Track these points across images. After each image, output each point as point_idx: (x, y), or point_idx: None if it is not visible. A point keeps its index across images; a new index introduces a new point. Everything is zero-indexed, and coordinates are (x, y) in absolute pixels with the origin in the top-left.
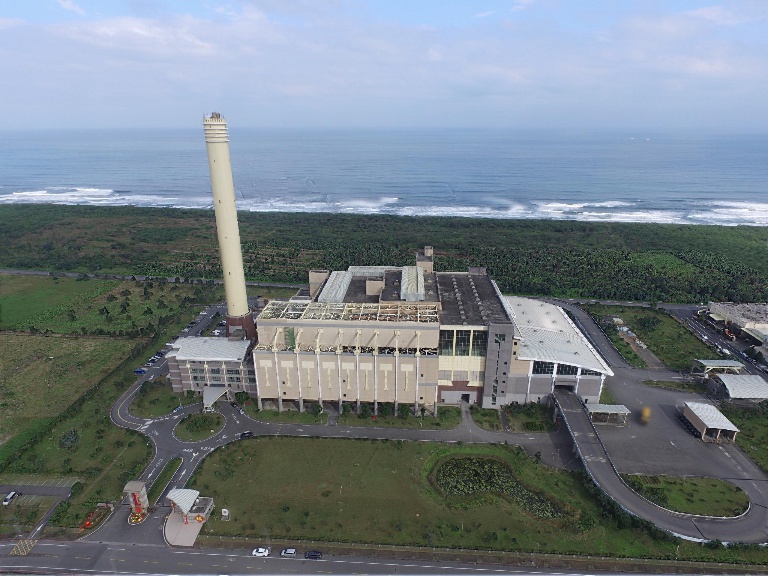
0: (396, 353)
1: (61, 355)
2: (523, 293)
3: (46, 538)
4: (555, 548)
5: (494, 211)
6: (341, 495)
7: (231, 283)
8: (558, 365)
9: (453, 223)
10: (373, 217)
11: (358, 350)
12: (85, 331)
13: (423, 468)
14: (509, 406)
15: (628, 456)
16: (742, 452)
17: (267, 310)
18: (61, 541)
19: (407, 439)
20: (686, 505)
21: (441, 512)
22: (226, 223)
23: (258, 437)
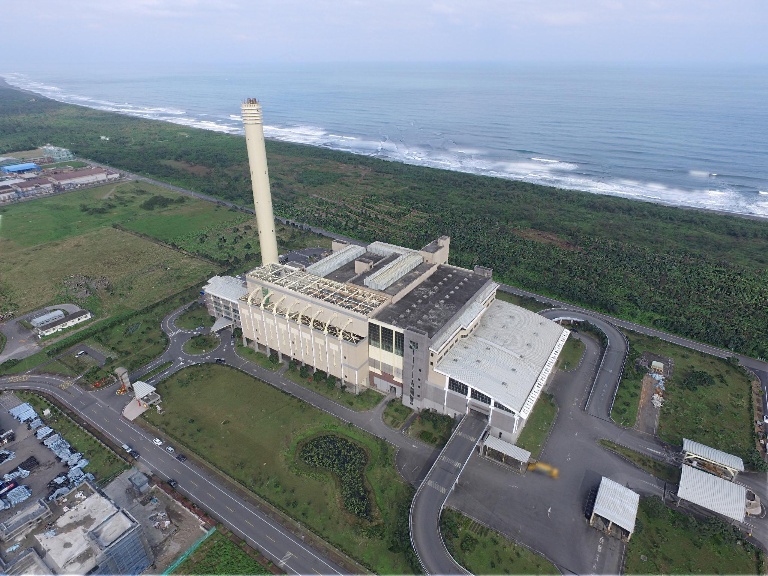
0: (324, 332)
1: (175, 268)
2: (583, 303)
3: (78, 384)
4: (330, 536)
5: (656, 196)
6: (233, 427)
7: (262, 240)
8: (472, 389)
9: (594, 204)
10: (512, 184)
11: (300, 321)
12: (199, 253)
13: (303, 432)
14: (426, 411)
15: (485, 500)
16: (622, 554)
17: (261, 269)
18: (82, 389)
19: (317, 406)
20: (484, 566)
21: (281, 469)
22: (257, 191)
23: (225, 365)
